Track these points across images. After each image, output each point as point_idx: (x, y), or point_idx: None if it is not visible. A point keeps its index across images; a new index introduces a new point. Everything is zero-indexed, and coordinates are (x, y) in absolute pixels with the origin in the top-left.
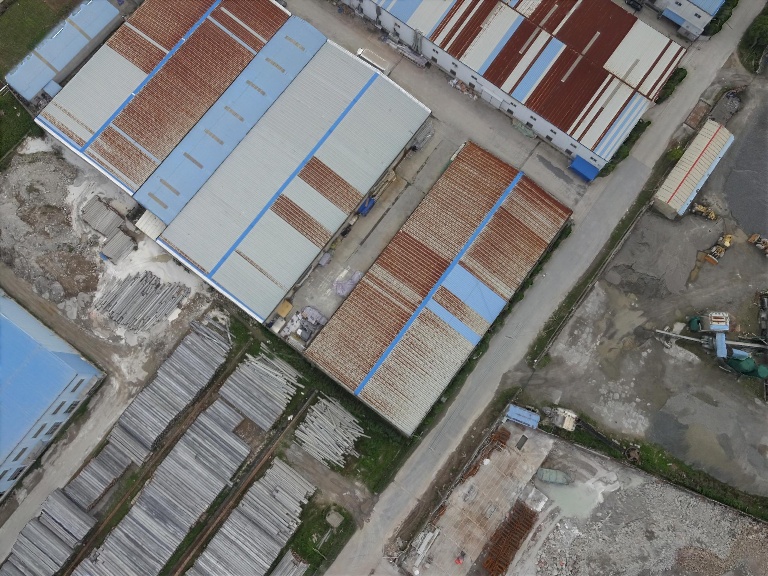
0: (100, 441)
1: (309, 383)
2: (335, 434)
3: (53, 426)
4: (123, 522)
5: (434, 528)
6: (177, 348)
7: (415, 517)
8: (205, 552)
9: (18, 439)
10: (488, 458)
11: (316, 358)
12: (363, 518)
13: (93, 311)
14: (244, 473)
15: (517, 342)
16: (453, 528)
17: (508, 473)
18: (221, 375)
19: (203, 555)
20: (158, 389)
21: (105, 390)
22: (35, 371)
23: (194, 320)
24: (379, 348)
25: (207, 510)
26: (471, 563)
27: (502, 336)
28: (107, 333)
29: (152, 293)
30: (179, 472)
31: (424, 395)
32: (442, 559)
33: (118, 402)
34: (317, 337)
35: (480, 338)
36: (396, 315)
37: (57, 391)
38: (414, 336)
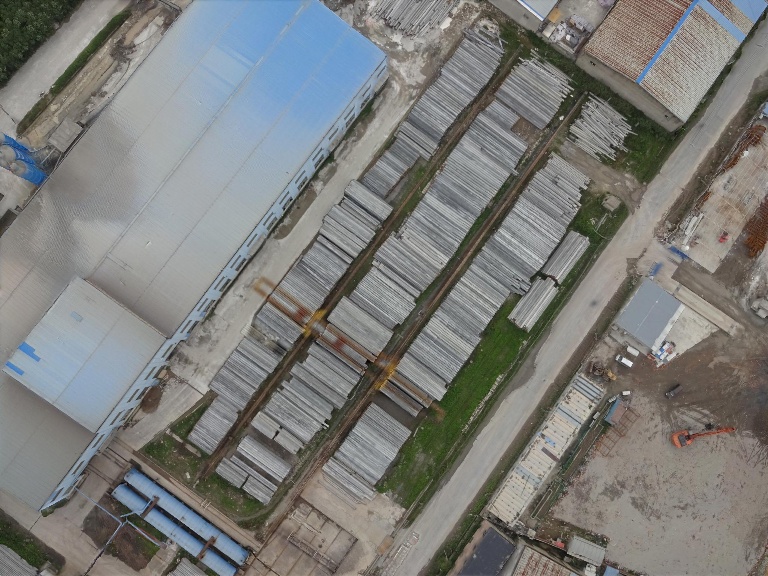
0: (387, 139)
1: (579, 85)
2: (611, 126)
3: (350, 118)
4: (419, 207)
5: (698, 213)
6: (457, 50)
7: (681, 204)
8: (500, 229)
9: (338, 114)
10: (747, 150)
11: (596, 53)
12: (634, 205)
13: (369, 19)
14: (523, 167)
15: (767, 50)
16: (715, 213)
17: (762, 166)
18: (495, 79)
19: (499, 231)
20: (443, 87)
21: (387, 92)
22: (348, 51)
23: (466, 27)
24: (656, 42)
25: (495, 196)
26: (732, 242)
27: (753, 45)
28: (384, 40)
29: (426, 0)
30: (467, 163)
31: (696, 86)
32: (707, 239)
33: (400, 103)
34: (594, 34)
35: (745, 36)
36: (670, 12)
37: (369, 71)
38: (687, 31)
